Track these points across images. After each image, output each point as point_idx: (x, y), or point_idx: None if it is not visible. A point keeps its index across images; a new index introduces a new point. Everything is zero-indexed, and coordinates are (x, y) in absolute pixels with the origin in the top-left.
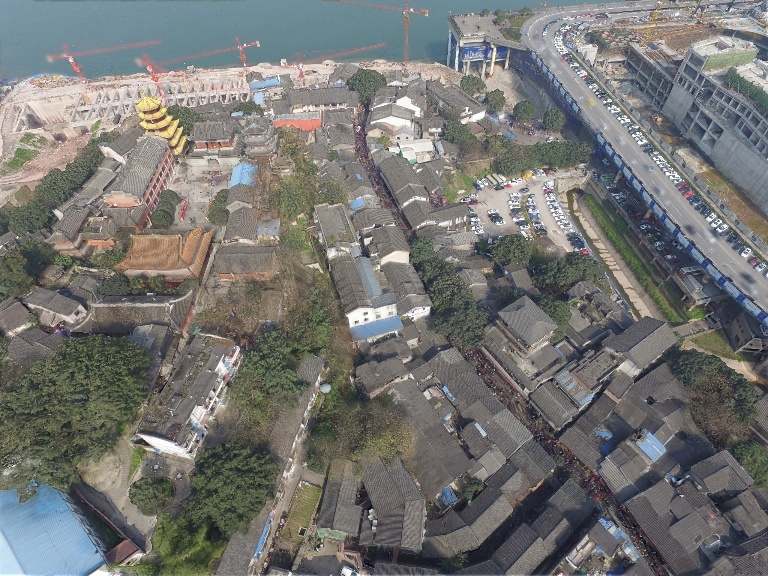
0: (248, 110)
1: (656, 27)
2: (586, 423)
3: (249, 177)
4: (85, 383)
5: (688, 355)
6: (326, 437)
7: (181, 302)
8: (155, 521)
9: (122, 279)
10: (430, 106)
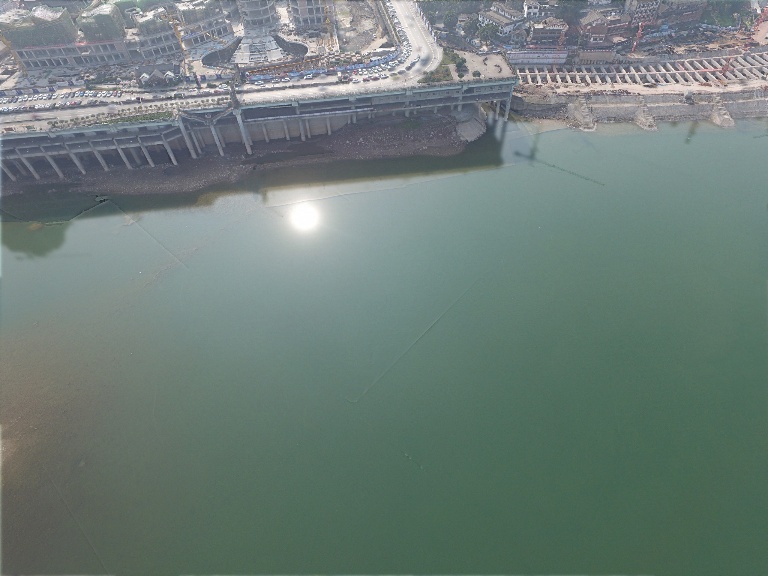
0: None
1: None
2: None
3: None
4: None
5: None
6: None
7: None
8: None
9: None
10: None
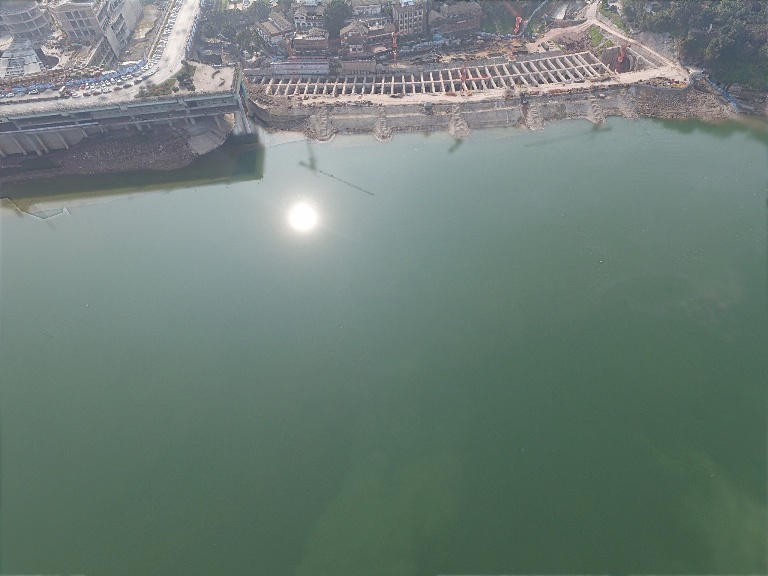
0: None
1: None
2: None
3: None
4: None
5: None
6: None
7: None
8: None
9: None
10: None
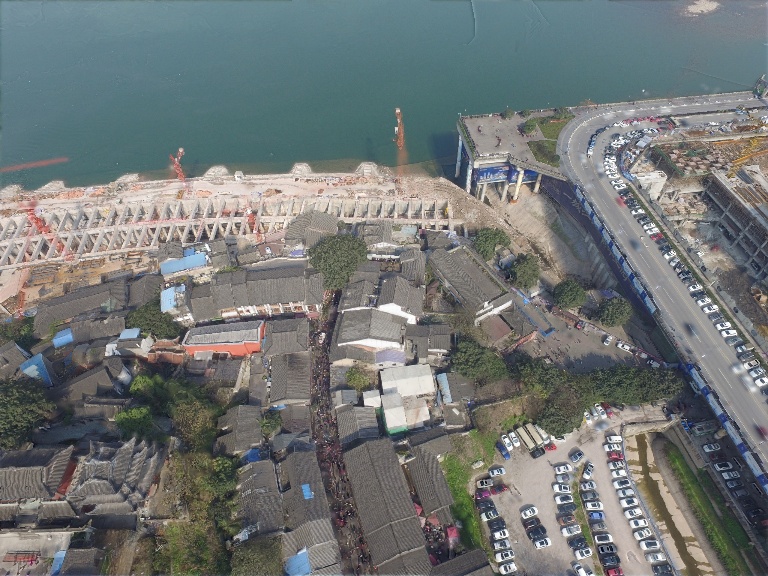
0: (147, 326)
1: (742, 140)
2: None
3: None
4: None
5: None
6: None
7: None
8: None
9: None
10: (431, 284)
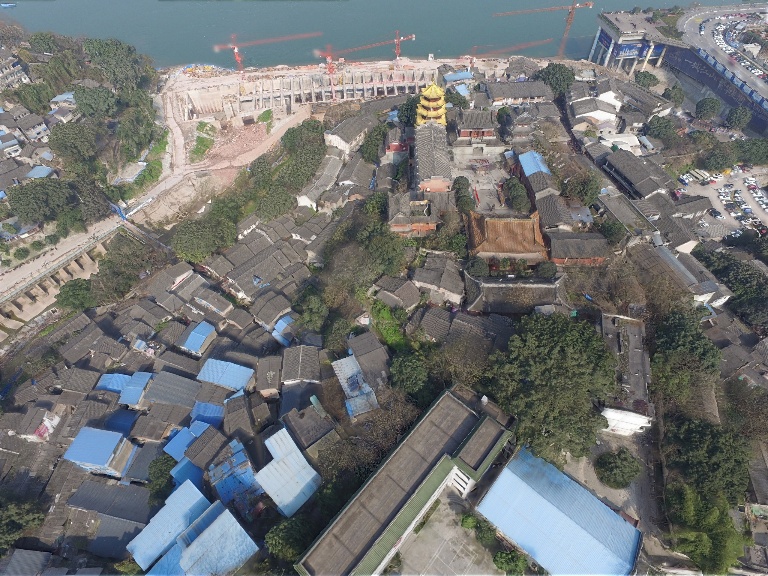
0: (457, 102)
1: None
2: None
3: (543, 165)
4: (576, 357)
5: None
6: (732, 418)
7: (559, 284)
8: (624, 494)
9: (484, 261)
10: None
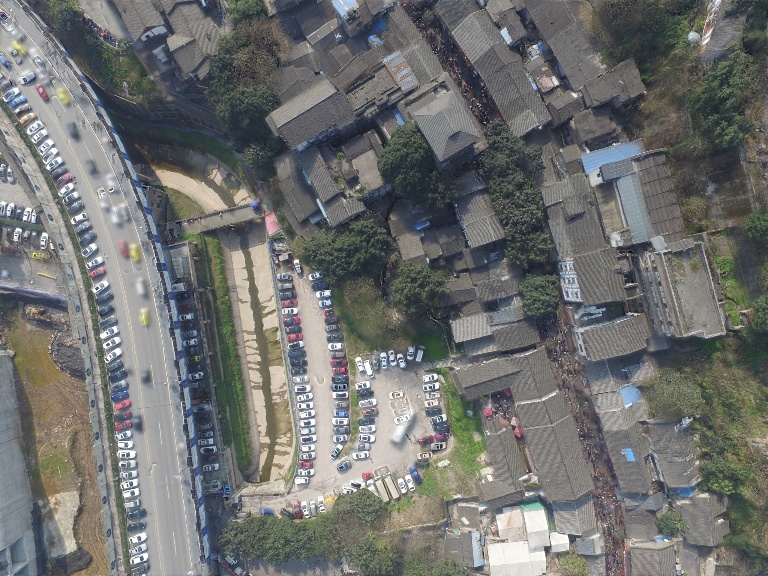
0: None
1: None
2: (394, 45)
3: None
4: None
5: (261, 108)
6: None
7: None
8: None
9: None
10: None
